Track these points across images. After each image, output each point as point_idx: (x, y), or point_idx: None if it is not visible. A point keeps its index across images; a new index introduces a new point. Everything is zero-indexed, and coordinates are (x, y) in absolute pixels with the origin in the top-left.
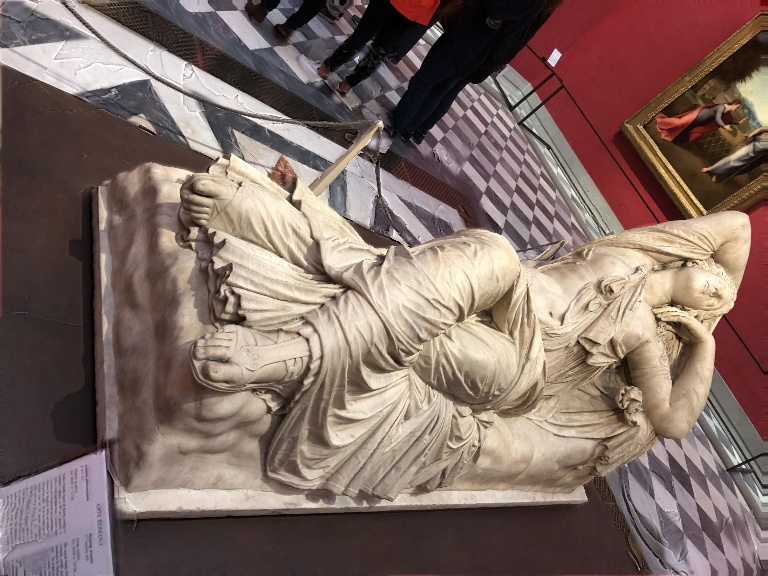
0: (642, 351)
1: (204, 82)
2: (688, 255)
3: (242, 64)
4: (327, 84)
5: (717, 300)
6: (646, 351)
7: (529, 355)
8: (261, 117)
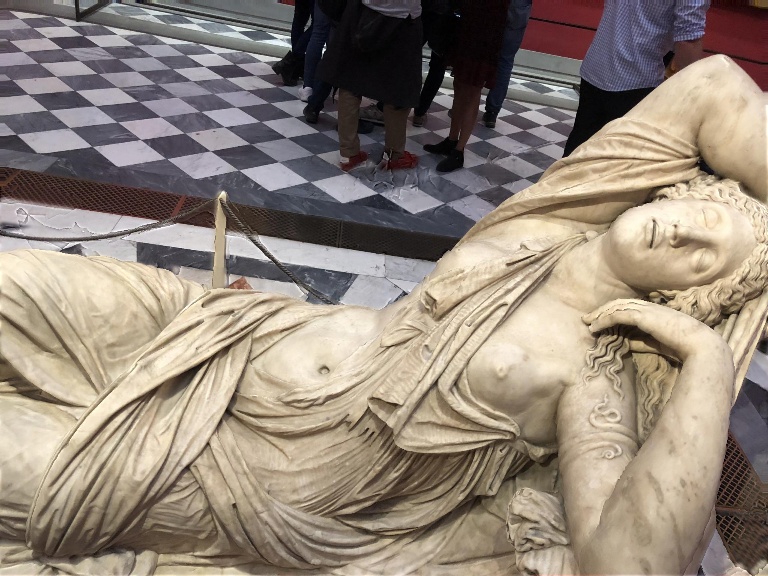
0: (560, 407)
1: (166, 232)
2: (621, 185)
3: (244, 206)
4: (382, 196)
5: (711, 251)
6: (564, 405)
7: (72, 436)
8: (107, 236)
